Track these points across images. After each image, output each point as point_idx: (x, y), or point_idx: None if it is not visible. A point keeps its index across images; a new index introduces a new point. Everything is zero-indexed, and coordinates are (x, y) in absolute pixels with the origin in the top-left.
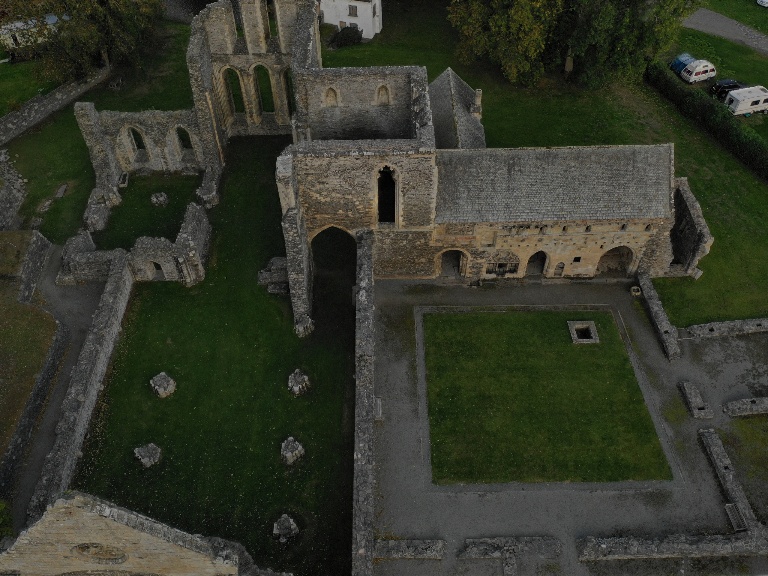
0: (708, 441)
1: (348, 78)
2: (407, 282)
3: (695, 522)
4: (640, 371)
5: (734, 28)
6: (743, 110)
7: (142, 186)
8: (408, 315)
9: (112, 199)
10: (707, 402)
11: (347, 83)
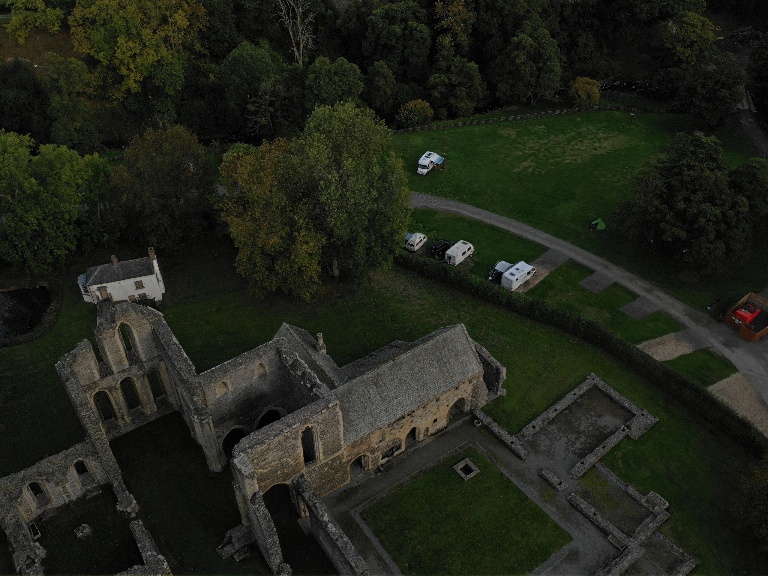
0: (576, 503)
1: (234, 370)
2: (332, 495)
3: (600, 559)
4: (513, 478)
5: (415, 198)
6: (459, 261)
7: (56, 528)
8: (350, 521)
9: (39, 555)
10: (559, 477)
11: (234, 373)
